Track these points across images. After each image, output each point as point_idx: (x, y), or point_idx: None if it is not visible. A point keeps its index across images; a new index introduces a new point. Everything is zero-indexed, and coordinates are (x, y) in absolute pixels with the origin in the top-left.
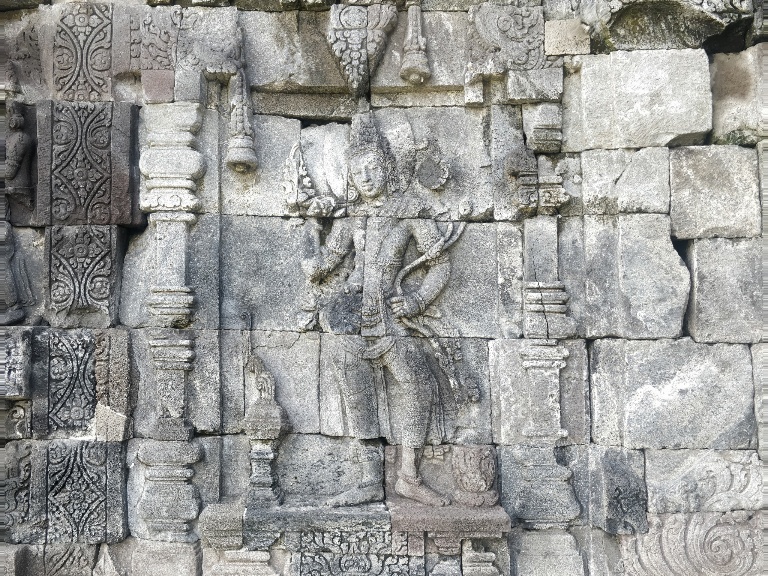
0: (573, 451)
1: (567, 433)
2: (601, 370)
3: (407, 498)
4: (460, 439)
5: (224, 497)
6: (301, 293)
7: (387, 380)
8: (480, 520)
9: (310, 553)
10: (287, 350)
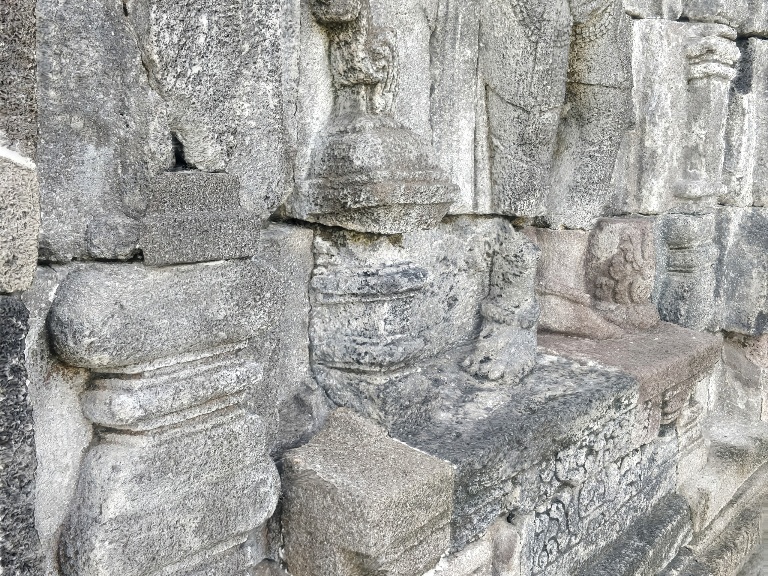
0: None
1: None
2: (754, 88)
3: (547, 332)
4: None
5: None
6: None
7: None
8: (707, 350)
9: (546, 503)
10: None
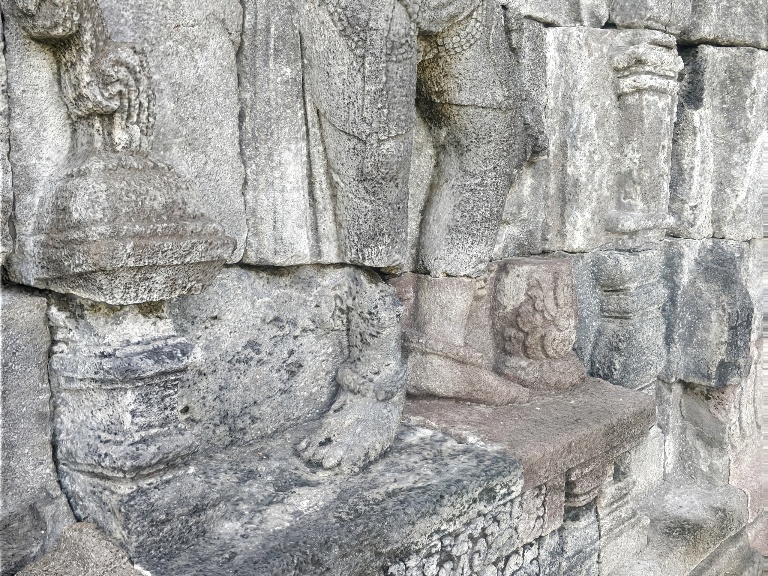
0: None
1: None
2: (707, 102)
3: (434, 397)
4: (498, 247)
5: None
6: None
7: None
8: (633, 414)
9: None
10: None
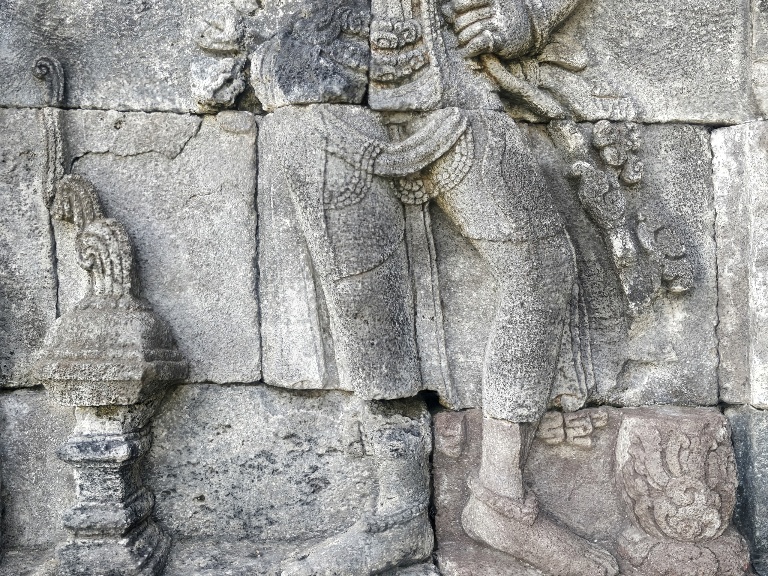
0: None
1: None
2: None
3: (495, 548)
4: (631, 391)
5: (12, 551)
6: (200, 5)
7: (438, 239)
8: None
9: None
10: (167, 162)
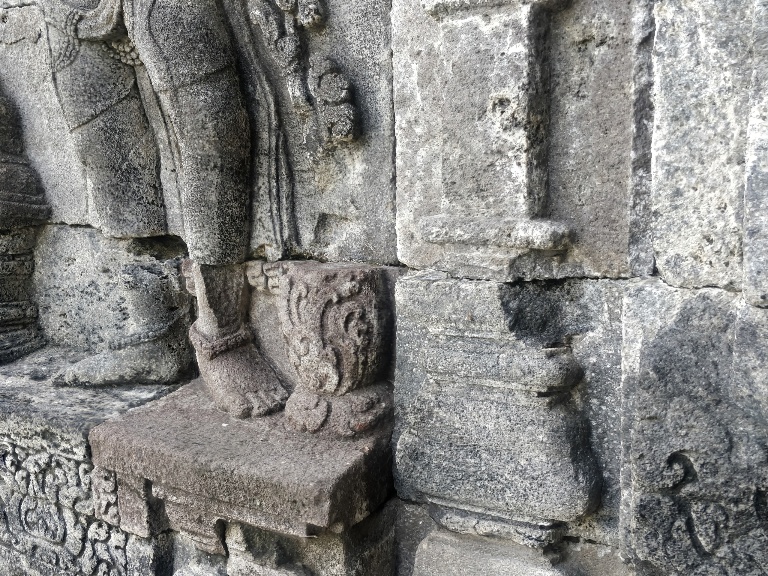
0: (590, 297)
1: (543, 233)
2: None
3: None
4: (332, 247)
5: None
6: None
7: None
8: (252, 477)
9: None
10: (34, 46)
